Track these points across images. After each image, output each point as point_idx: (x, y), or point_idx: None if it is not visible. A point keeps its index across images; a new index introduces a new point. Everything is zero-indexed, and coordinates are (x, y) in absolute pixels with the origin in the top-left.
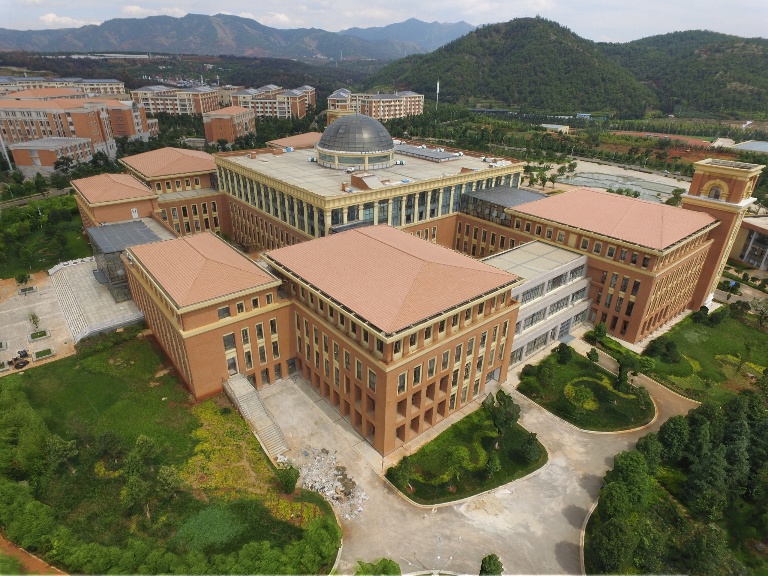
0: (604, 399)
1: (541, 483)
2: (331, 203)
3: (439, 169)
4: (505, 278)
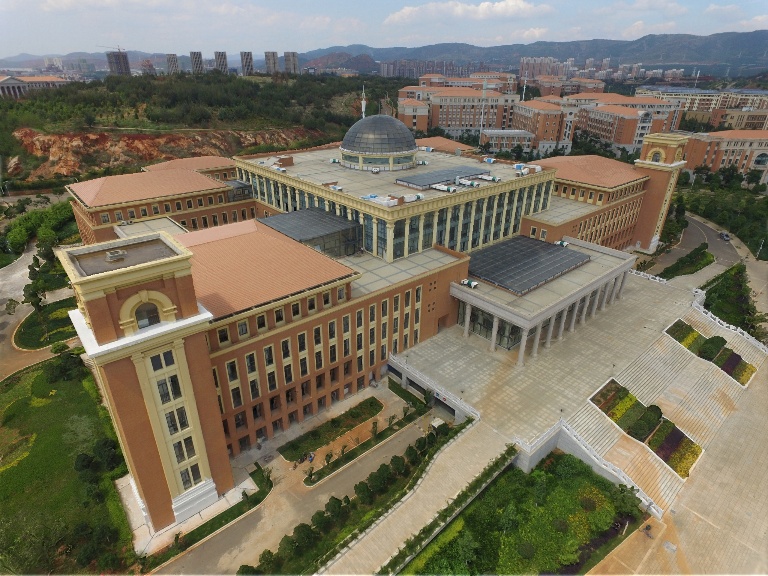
0: (52, 322)
1: (22, 287)
2: (237, 162)
3: (356, 182)
4: (90, 202)
